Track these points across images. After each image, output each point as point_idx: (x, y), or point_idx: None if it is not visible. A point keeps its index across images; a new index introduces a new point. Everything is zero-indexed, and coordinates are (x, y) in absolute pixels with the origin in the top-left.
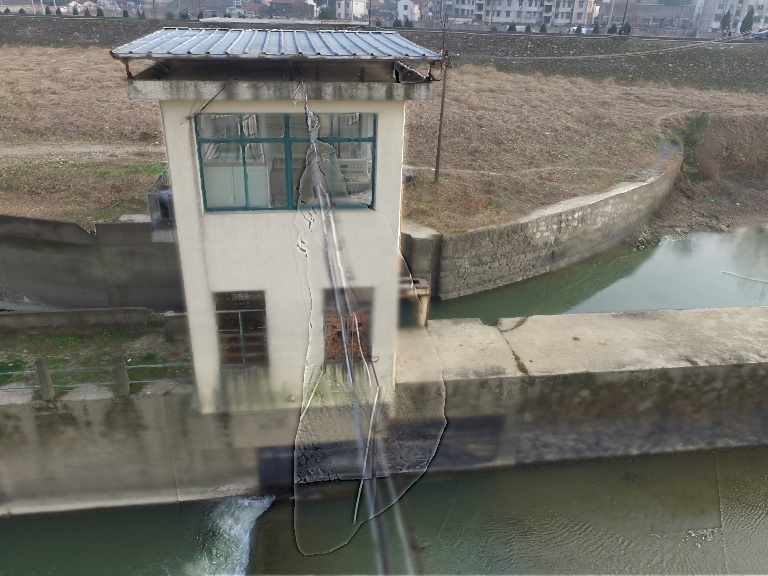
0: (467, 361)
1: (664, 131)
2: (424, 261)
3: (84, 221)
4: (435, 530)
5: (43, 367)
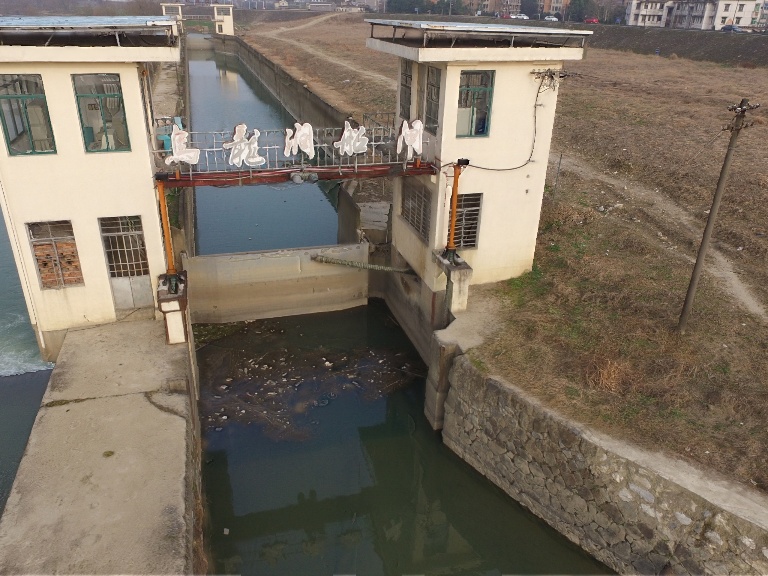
0: (86, 367)
1: None
2: None
3: None
4: None
5: None
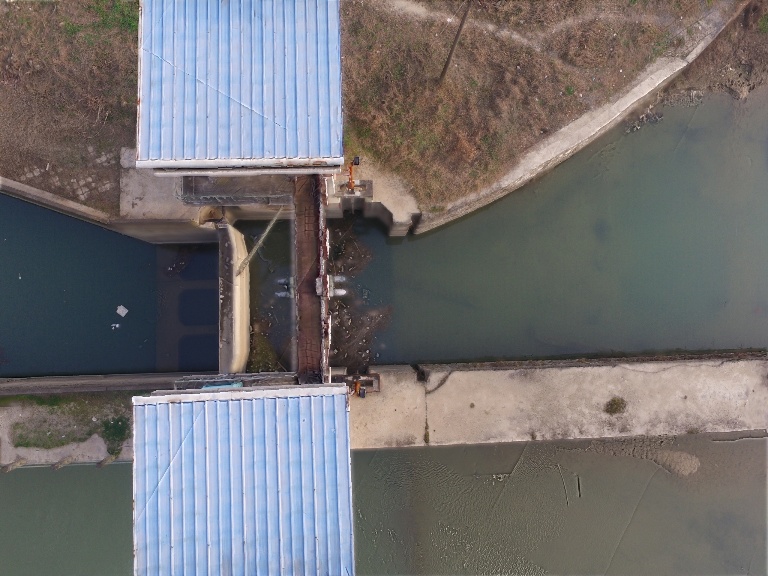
0: (395, 429)
1: None
2: (402, 227)
3: (88, 160)
4: (368, 463)
5: None
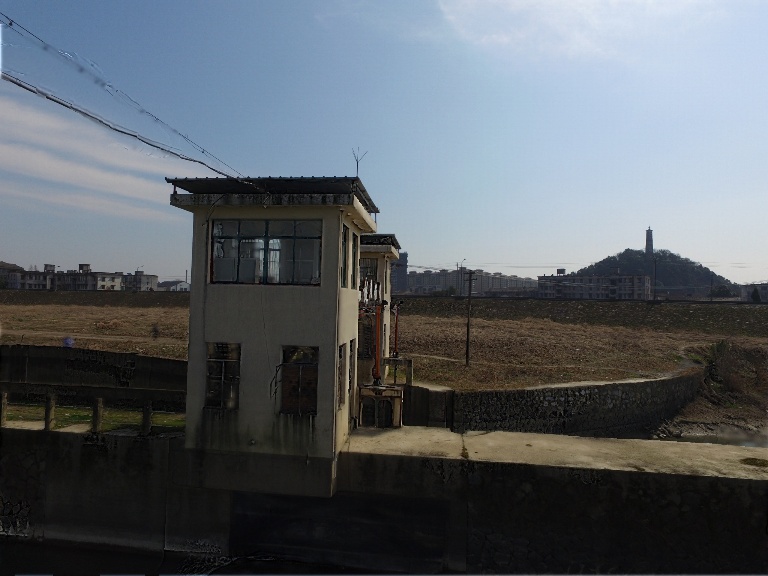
0: (418, 446)
1: (686, 354)
2: (439, 411)
3: None
4: None
5: (98, 404)
